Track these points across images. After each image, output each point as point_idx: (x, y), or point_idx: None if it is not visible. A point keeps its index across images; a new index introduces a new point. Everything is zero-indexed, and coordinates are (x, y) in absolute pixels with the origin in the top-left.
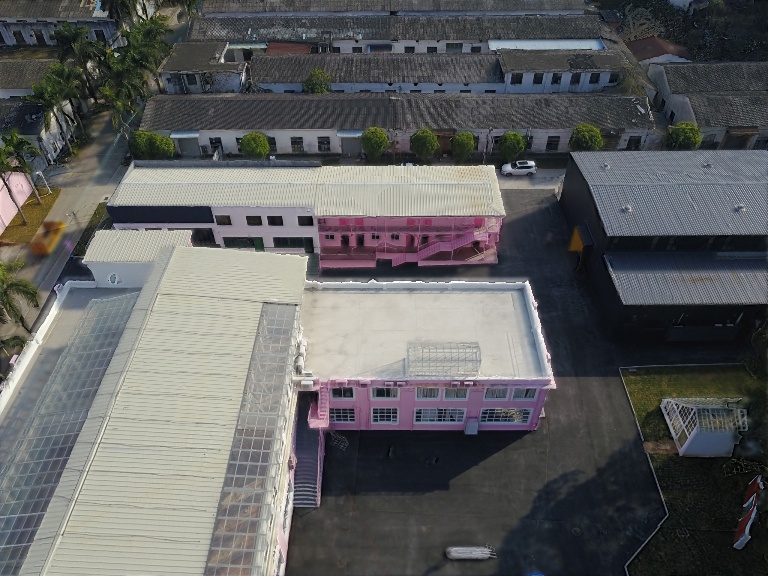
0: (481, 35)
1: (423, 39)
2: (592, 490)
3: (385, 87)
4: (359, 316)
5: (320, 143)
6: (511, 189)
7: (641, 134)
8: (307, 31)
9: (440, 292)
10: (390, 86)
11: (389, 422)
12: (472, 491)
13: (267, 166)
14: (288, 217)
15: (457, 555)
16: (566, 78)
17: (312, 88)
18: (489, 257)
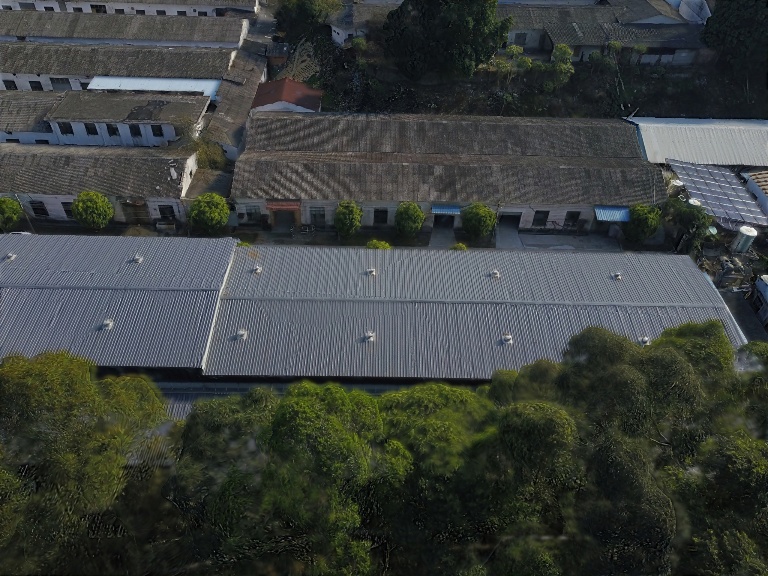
0: (88, 70)
1: (19, 72)
2: None
3: None
4: None
5: None
6: None
7: (170, 203)
8: None
9: None
10: None
11: None
12: None
13: None
14: None
15: None
16: (124, 129)
17: None
18: None
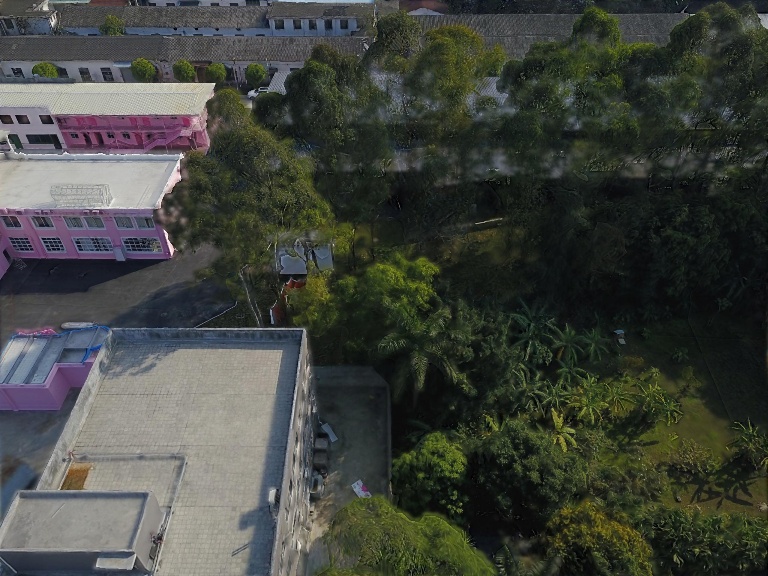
0: None
1: None
2: (190, 292)
3: (172, 31)
4: (45, 175)
5: (104, 73)
6: (249, 108)
7: None
8: None
9: (116, 162)
10: (176, 30)
11: (59, 251)
12: (102, 293)
13: (33, 82)
14: (32, 116)
15: (68, 326)
16: (320, 24)
17: (106, 30)
18: None
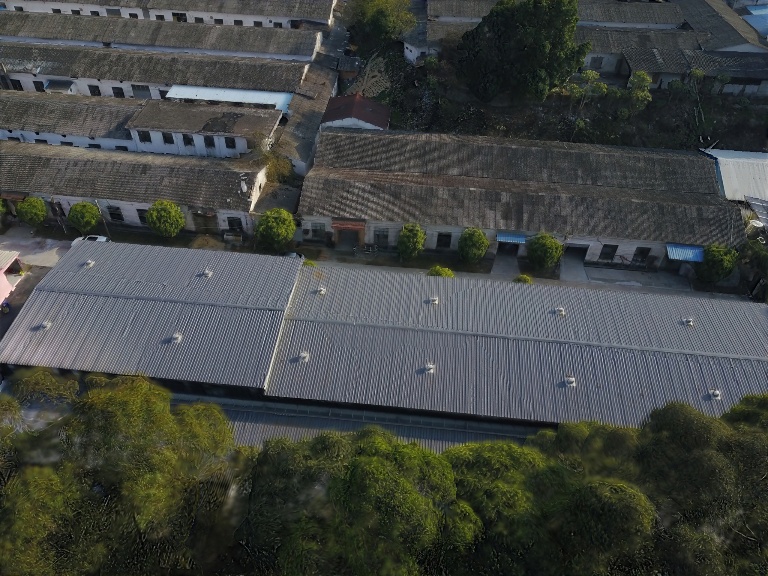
0: (167, 78)
1: (103, 78)
2: None
3: (6, 133)
4: None
5: None
6: None
7: (239, 216)
8: None
9: None
10: (11, 133)
11: None
12: None
13: None
14: None
15: None
16: (199, 140)
17: None
18: None
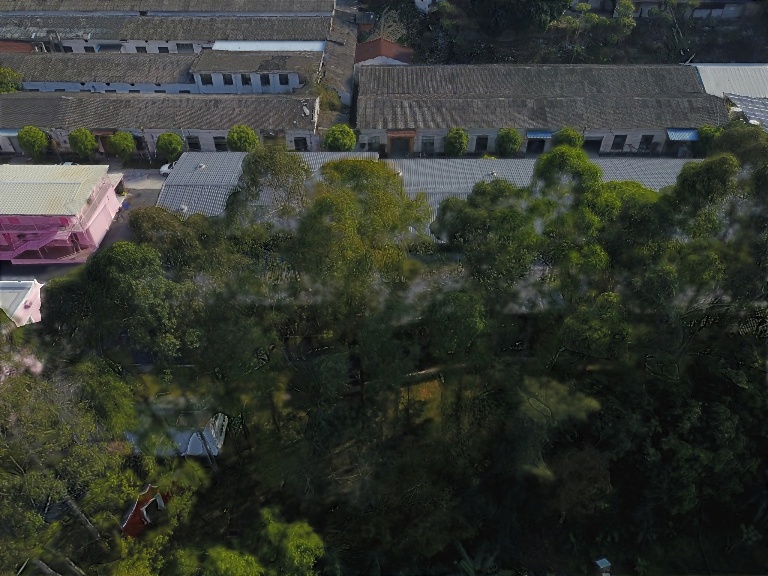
0: (209, 36)
1: (151, 39)
2: None
3: (79, 86)
4: None
5: None
6: None
7: (304, 135)
8: (38, 30)
9: None
10: (83, 86)
11: None
12: None
13: None
14: None
15: None
16: (255, 79)
17: None
18: (82, 256)
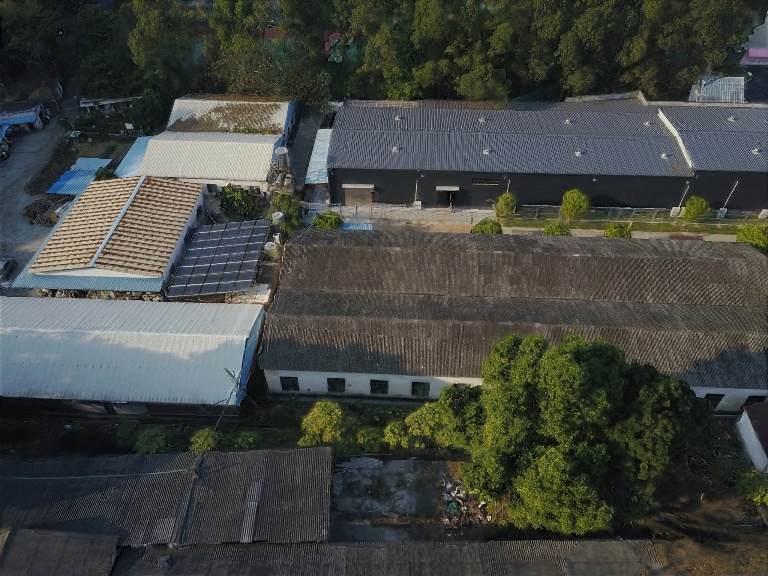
0: None
1: None
2: None
3: None
4: None
5: None
6: None
7: None
8: None
9: None
10: None
11: None
12: None
13: None
14: None
15: None
16: None
17: None
18: None
